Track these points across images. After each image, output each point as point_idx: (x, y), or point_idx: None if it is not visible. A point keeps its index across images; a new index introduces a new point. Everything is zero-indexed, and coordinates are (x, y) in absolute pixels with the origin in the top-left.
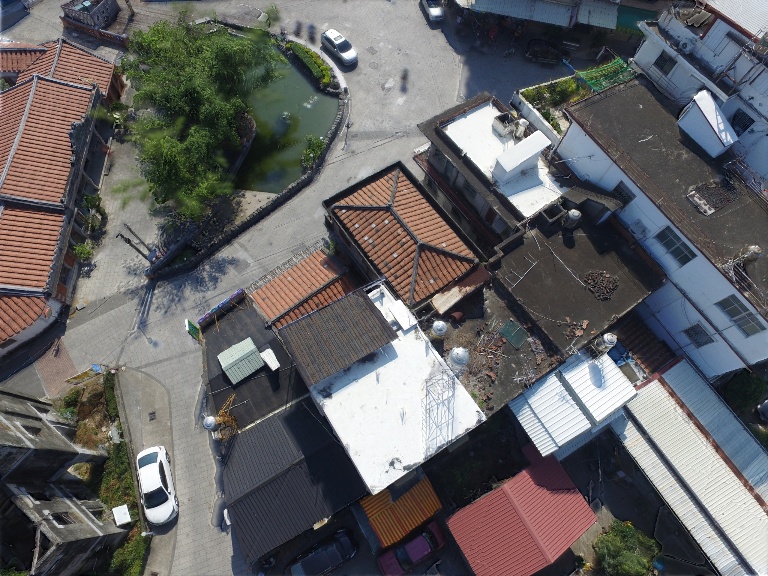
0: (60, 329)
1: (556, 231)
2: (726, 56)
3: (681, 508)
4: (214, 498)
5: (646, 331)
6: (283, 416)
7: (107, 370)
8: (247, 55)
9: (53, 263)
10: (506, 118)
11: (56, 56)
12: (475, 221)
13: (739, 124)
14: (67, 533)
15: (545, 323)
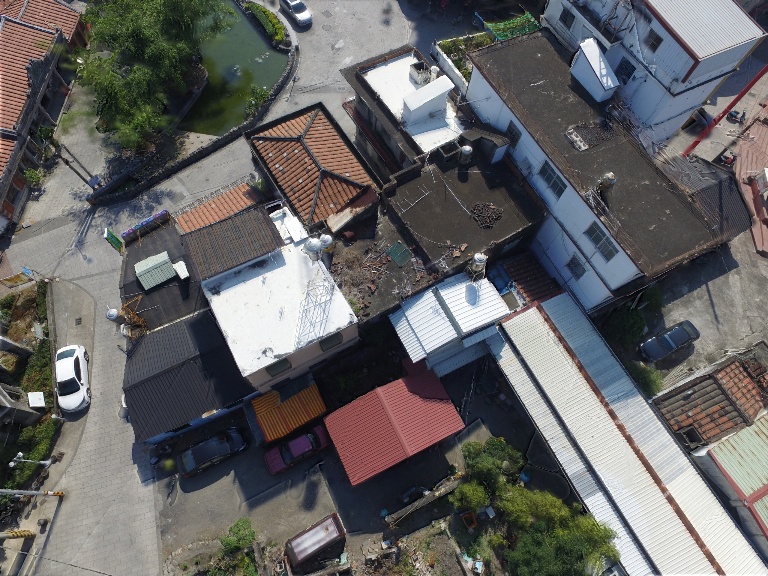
0: (5, 243)
1: (453, 167)
2: (609, 6)
3: (543, 421)
4: None
5: (538, 268)
6: (189, 322)
7: (42, 279)
8: (194, 4)
9: (1, 181)
10: (422, 67)
11: (25, 2)
12: (389, 162)
13: (625, 73)
14: None
15: (427, 244)
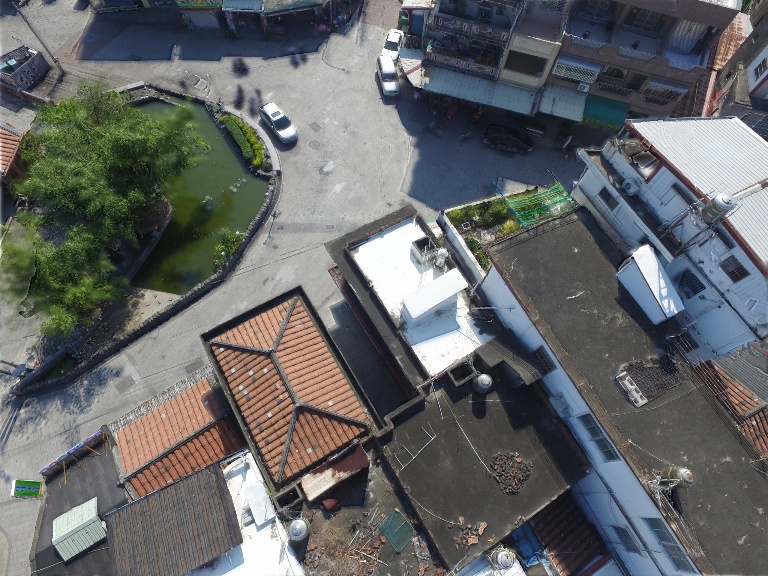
0: None
1: (466, 394)
2: (672, 210)
3: None
4: None
5: (573, 512)
6: None
7: None
8: (151, 144)
9: None
10: (427, 242)
11: None
12: (385, 359)
13: (689, 284)
14: None
15: (433, 523)
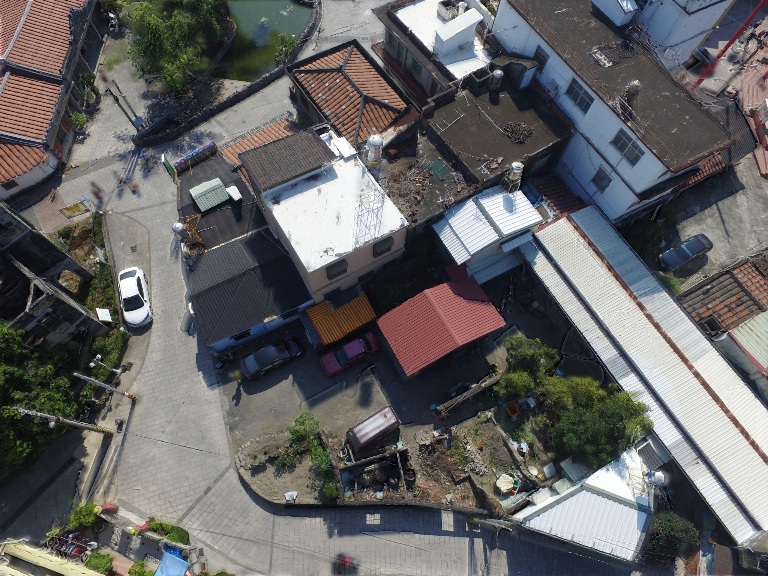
0: (56, 182)
1: (484, 92)
2: None
3: (577, 316)
4: (184, 311)
5: (564, 187)
6: (244, 241)
7: None
8: None
9: (51, 121)
10: (449, 4)
11: None
12: (420, 95)
13: None
14: (56, 294)
15: (466, 158)
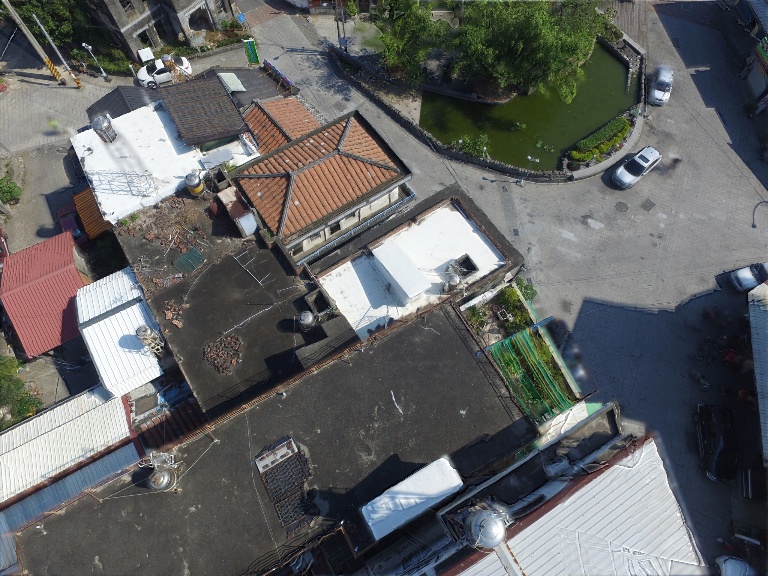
0: (292, 12)
1: None
2: None
3: (5, 442)
4: None
5: None
6: None
7: None
8: (543, 44)
9: None
10: None
11: None
12: None
13: None
14: None
15: (187, 283)
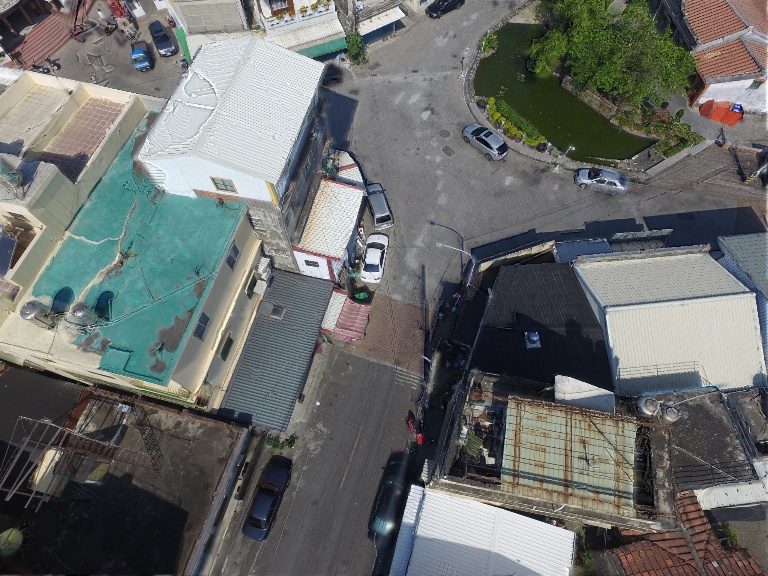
0: None
1: None
2: None
3: None
4: None
5: None
6: None
7: None
8: None
9: None
10: None
11: None
12: None
13: None
14: None
15: None
